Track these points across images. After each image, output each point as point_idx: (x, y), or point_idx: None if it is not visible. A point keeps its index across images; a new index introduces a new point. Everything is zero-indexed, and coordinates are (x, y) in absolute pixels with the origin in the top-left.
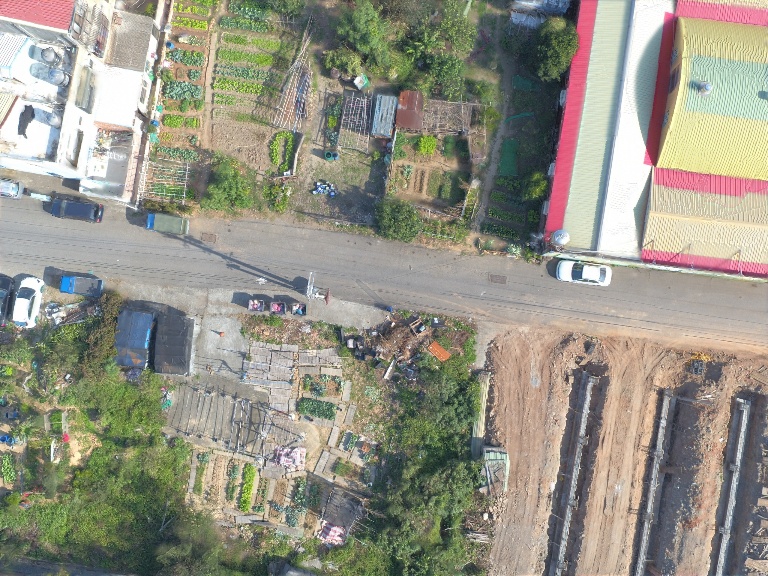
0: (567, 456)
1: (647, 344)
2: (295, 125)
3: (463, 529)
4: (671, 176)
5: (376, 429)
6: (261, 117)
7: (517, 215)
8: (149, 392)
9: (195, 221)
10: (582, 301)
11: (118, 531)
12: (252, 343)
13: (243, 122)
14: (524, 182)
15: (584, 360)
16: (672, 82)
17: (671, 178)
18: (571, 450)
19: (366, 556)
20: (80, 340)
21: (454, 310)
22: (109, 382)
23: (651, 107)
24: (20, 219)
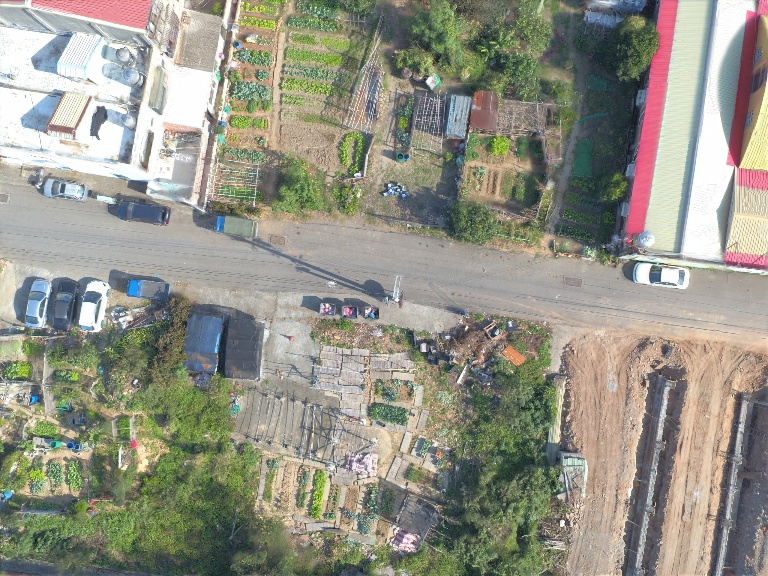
0: (643, 461)
1: (725, 348)
2: (367, 126)
3: (539, 536)
4: (755, 177)
5: (449, 434)
6: (330, 118)
7: (592, 217)
8: (219, 397)
9: (263, 223)
10: (659, 304)
11: (187, 539)
12: (322, 347)
13: (312, 123)
14: (601, 183)
15: (661, 364)
16: (756, 81)
17: (755, 179)
18: (647, 455)
19: (440, 564)
20: (148, 345)
21: (528, 313)
22: (177, 387)
23: (733, 107)
24: (85, 222)
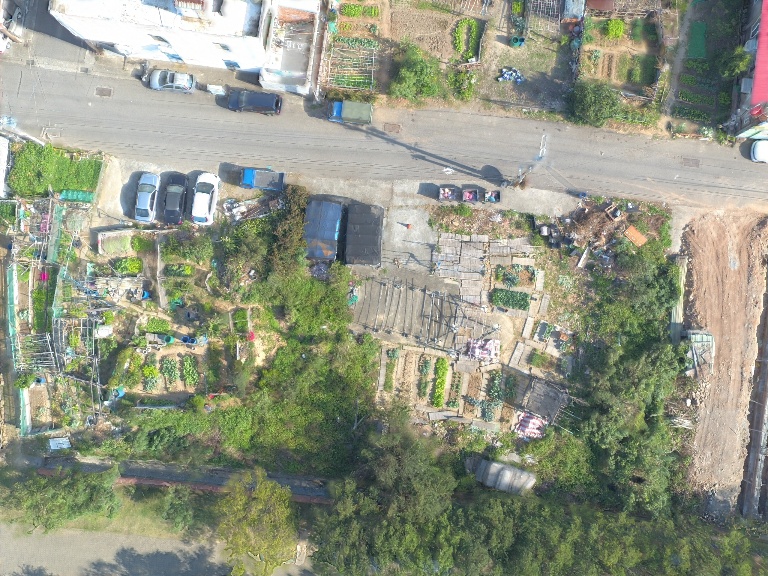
0: (762, 342)
1: None
2: (483, 8)
3: (667, 416)
4: None
5: (571, 319)
6: (442, 4)
7: (707, 98)
8: (339, 285)
9: (377, 111)
10: None
11: (308, 432)
12: (440, 234)
13: (423, 9)
14: (719, 61)
15: None
16: None
17: None
18: (767, 335)
19: (567, 448)
20: (263, 235)
21: (647, 195)
22: (295, 277)
23: None
24: (192, 114)
